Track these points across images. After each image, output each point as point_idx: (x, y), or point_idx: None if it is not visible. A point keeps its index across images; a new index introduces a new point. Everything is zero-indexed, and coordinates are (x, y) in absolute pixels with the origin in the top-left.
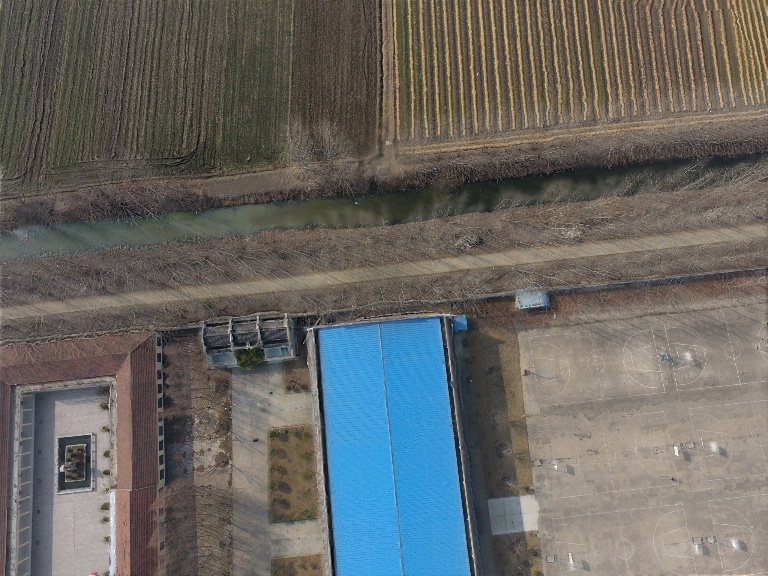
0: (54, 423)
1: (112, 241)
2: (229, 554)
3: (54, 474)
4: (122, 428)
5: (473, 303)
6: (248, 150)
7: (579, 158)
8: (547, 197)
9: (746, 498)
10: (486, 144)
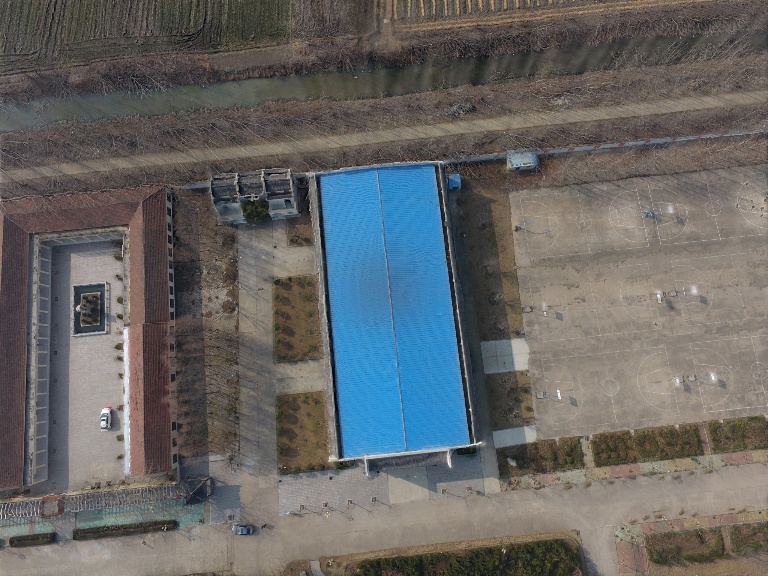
0: (70, 273)
1: (123, 112)
2: (236, 391)
3: (70, 319)
4: (135, 270)
5: (467, 165)
6: (252, 28)
7: (568, 35)
8: (537, 70)
9: (725, 341)
10: (479, 22)
